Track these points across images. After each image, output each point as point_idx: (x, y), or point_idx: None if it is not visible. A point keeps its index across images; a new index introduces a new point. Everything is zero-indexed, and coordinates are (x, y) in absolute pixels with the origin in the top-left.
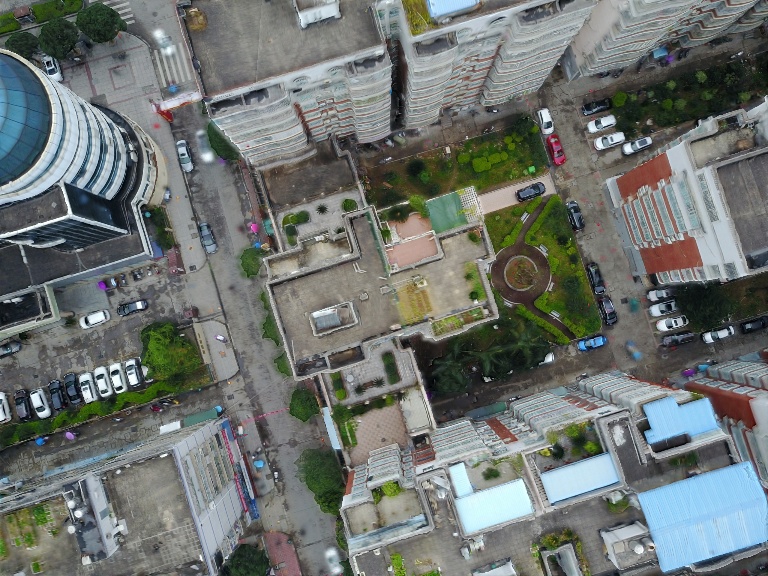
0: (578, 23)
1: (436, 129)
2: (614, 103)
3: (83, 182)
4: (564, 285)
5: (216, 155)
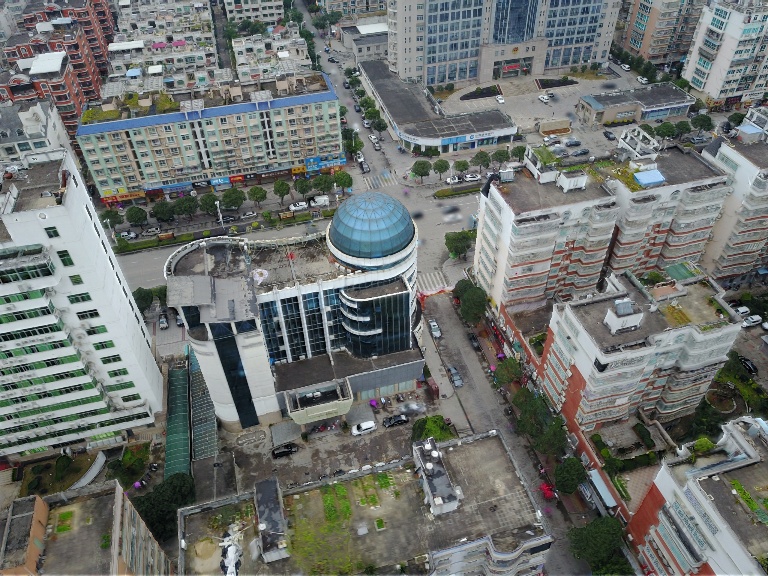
0: (720, 203)
1: None
2: (743, 299)
3: None
4: (762, 402)
5: (456, 329)
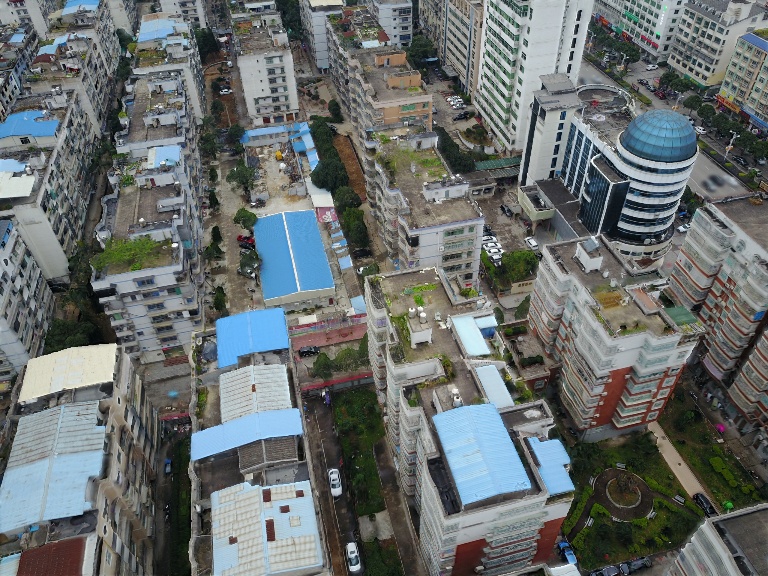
0: None
1: (736, 434)
2: None
3: (630, 197)
4: None
5: None
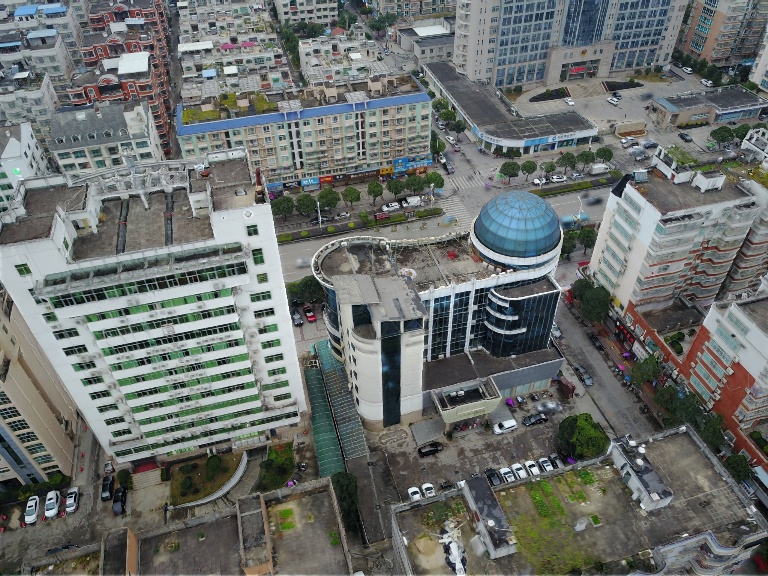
0: None
1: None
2: None
3: None
4: None
5: (574, 329)
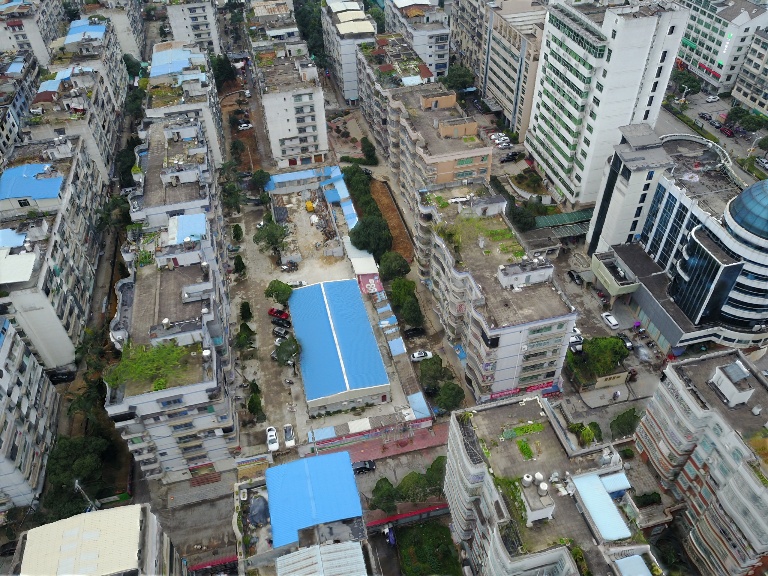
0: None
1: None
2: None
3: (742, 280)
4: None
5: None
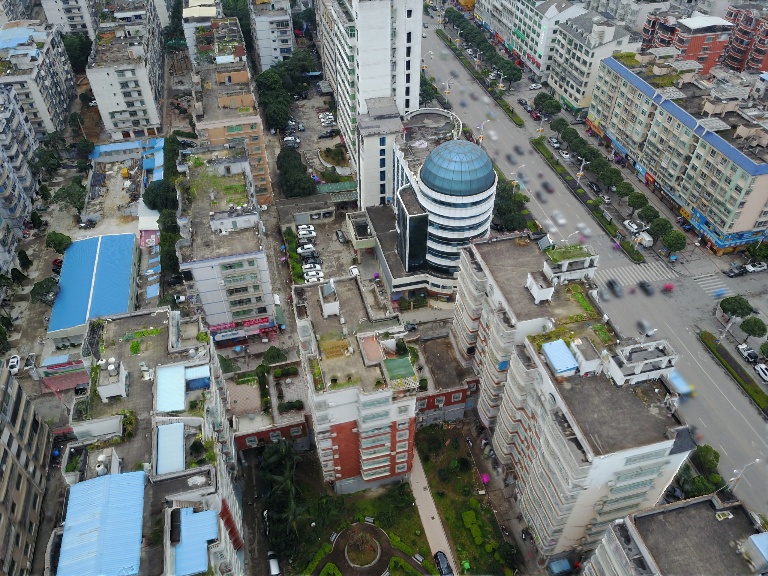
0: None
1: (501, 484)
2: None
3: (431, 230)
4: None
5: None
